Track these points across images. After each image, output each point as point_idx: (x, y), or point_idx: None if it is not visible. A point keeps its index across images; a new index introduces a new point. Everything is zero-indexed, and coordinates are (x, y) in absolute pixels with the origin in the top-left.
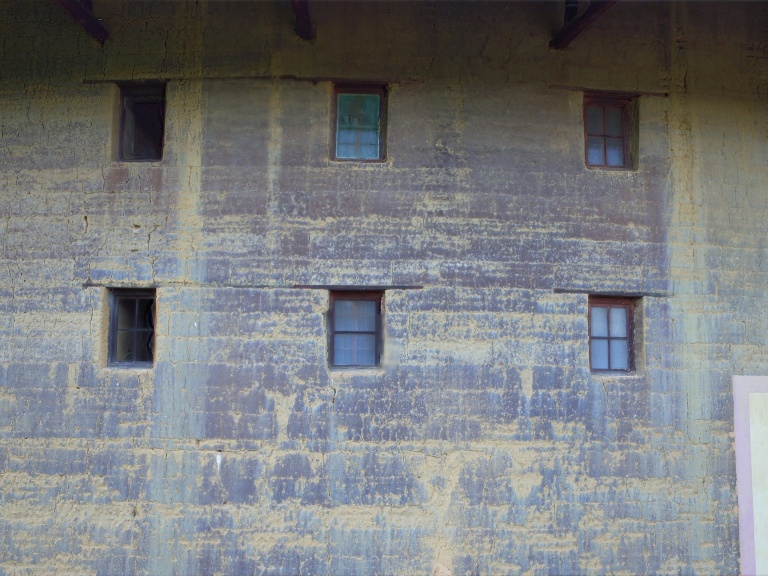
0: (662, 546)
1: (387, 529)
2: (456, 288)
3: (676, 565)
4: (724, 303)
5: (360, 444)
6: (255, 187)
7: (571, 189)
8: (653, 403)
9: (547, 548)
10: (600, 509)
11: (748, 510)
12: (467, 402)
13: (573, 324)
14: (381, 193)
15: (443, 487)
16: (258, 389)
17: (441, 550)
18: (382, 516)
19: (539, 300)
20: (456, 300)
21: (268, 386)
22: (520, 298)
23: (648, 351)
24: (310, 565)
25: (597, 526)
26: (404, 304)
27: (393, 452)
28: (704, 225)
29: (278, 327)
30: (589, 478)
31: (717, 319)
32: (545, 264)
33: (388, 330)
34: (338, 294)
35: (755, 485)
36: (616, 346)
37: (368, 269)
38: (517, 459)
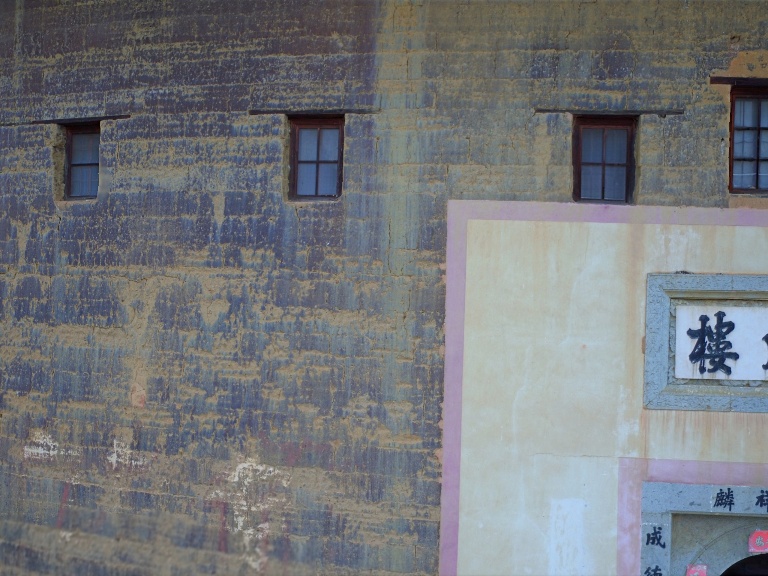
0: (351, 382)
1: (96, 348)
2: (158, 115)
3: (366, 404)
4: (443, 117)
5: (78, 268)
6: (6, 32)
7: (272, 2)
8: (349, 230)
9: (231, 375)
10: (286, 339)
11: (457, 351)
12: (164, 228)
13: (267, 147)
14: (99, 26)
15: (142, 311)
16: (6, 218)
17: (138, 370)
18: (92, 336)
19: (234, 123)
20: (158, 127)
21: (13, 215)
22: (216, 122)
23: (347, 174)
24: (39, 377)
25: (282, 357)
26: (114, 134)
27: (103, 276)
28: (423, 28)
29: (20, 161)
30: (276, 307)
31: (433, 136)
32: (242, 85)
33: (101, 160)
34: (73, 128)
35: (468, 324)
36: (325, 170)
37: (87, 102)
38: (207, 286)
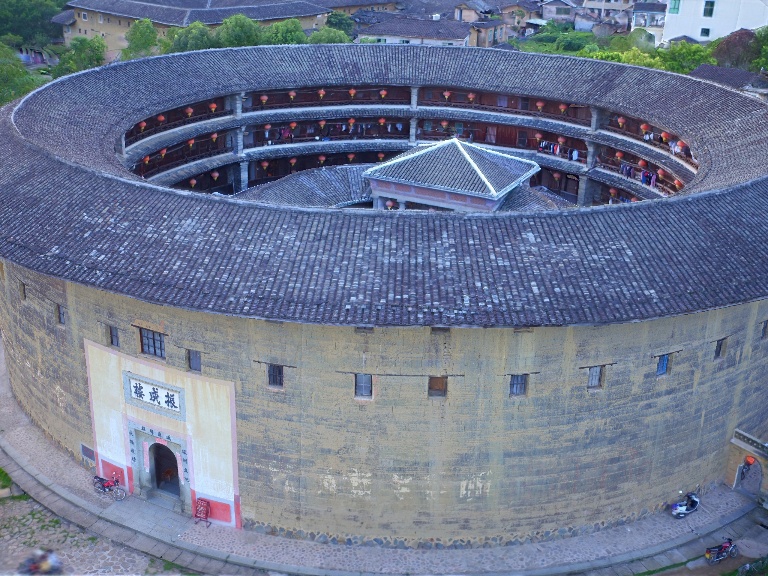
0: None
1: None
2: None
3: None
4: None
5: None
6: None
7: None
8: None
9: (53, 364)
10: None
11: None
12: None
13: (51, 309)
14: None
15: None
16: None
17: None
18: None
19: None
20: None
21: None
22: None
23: None
24: None
25: None
26: None
27: None
28: (74, 291)
29: None
30: None
31: (79, 320)
32: None
33: None
34: None
35: None
36: None
37: None
38: None
